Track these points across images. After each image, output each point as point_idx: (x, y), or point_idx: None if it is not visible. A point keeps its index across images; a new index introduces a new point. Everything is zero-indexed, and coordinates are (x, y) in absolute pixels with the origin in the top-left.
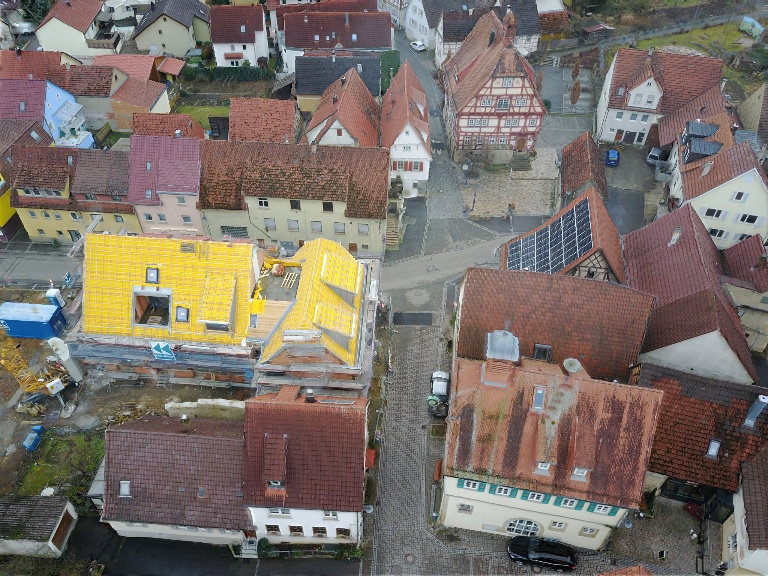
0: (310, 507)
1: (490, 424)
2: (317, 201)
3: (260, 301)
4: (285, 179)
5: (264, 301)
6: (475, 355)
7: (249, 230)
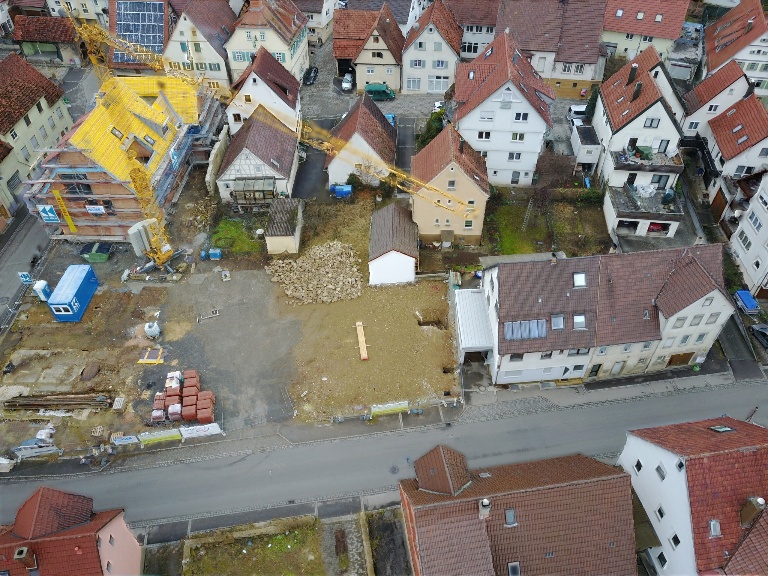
0: (297, 94)
1: (275, 22)
2: (34, 106)
3: (154, 104)
4: (4, 108)
5: (155, 103)
6: (220, 48)
7: (20, 171)
